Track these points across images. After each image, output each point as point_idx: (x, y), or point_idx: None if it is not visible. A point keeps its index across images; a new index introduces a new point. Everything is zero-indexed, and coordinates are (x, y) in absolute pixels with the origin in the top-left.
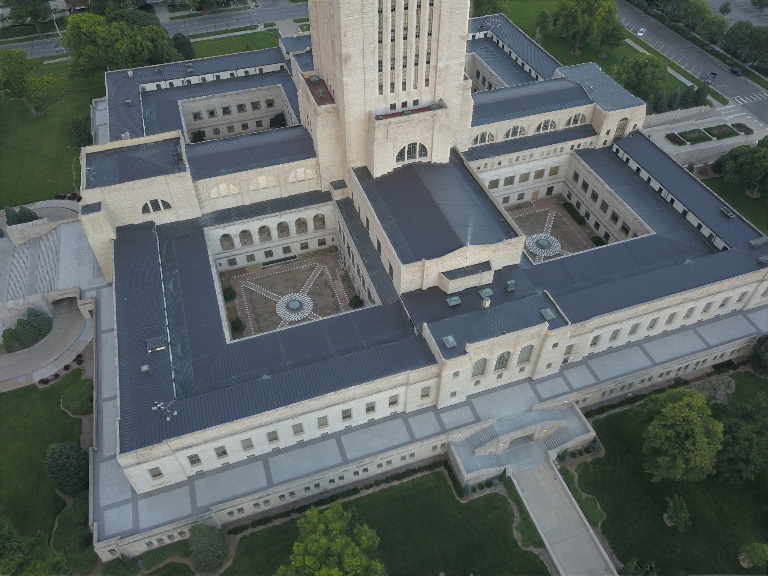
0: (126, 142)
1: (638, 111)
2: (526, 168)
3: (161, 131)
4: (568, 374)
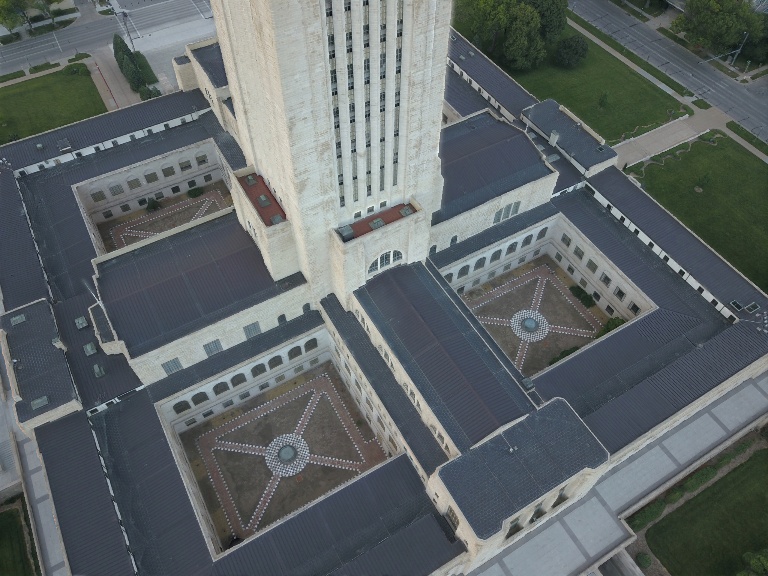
0: None
1: None
2: None
3: None
4: None
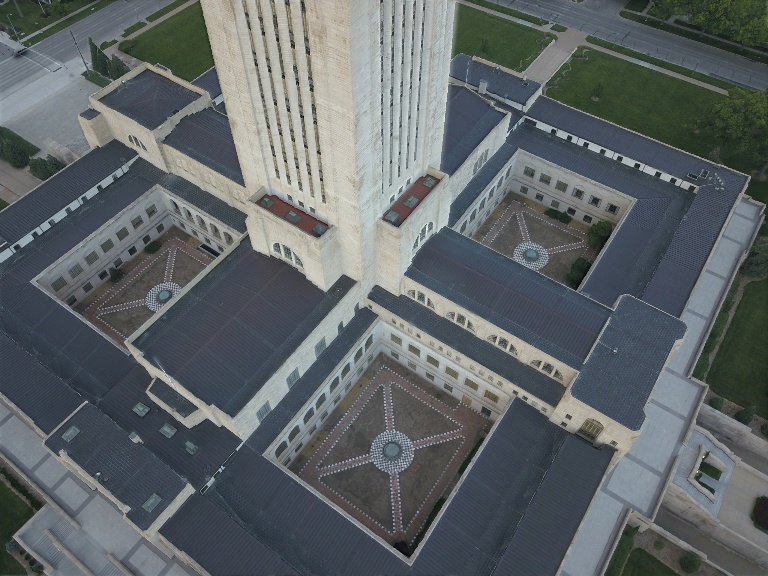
0: (171, 77)
1: (619, 430)
2: (453, 366)
3: None
4: (174, 570)
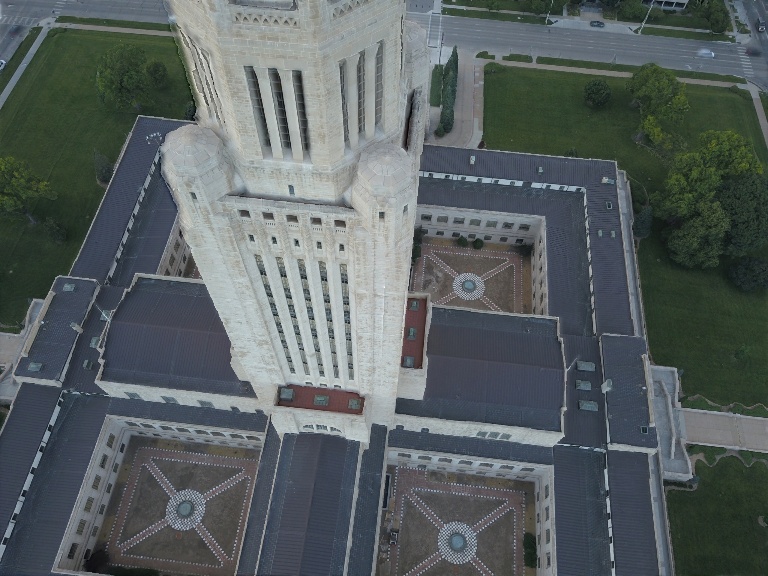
0: None
1: None
2: None
3: (493, 195)
4: None
